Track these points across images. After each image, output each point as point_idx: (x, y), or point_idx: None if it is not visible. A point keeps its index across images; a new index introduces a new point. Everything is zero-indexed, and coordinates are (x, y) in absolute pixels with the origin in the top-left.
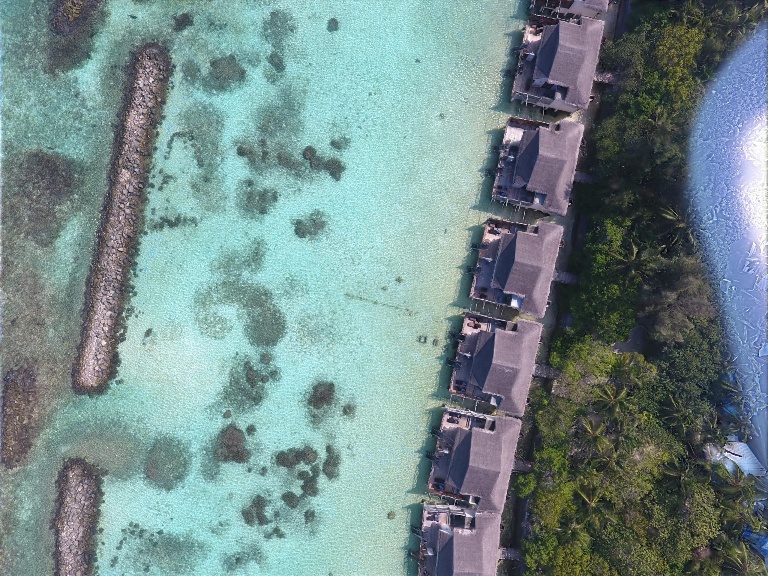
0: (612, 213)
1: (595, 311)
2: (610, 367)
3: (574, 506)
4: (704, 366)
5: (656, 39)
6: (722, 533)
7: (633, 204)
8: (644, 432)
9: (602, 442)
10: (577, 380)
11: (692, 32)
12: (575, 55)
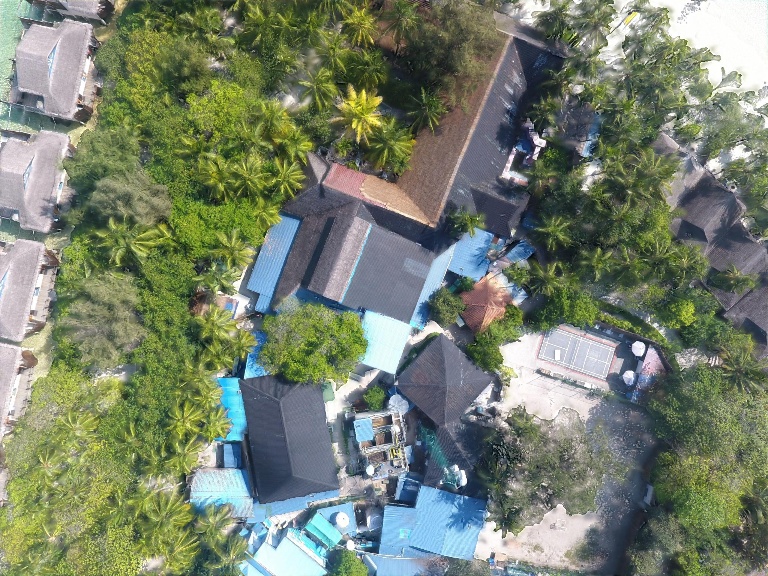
0: (78, 230)
1: (57, 334)
2: (72, 393)
3: (30, 541)
4: (156, 392)
5: (130, 44)
6: (143, 570)
7: (84, 221)
8: (95, 462)
9: (35, 475)
10: (42, 407)
11: (153, 36)
12: (36, 61)
